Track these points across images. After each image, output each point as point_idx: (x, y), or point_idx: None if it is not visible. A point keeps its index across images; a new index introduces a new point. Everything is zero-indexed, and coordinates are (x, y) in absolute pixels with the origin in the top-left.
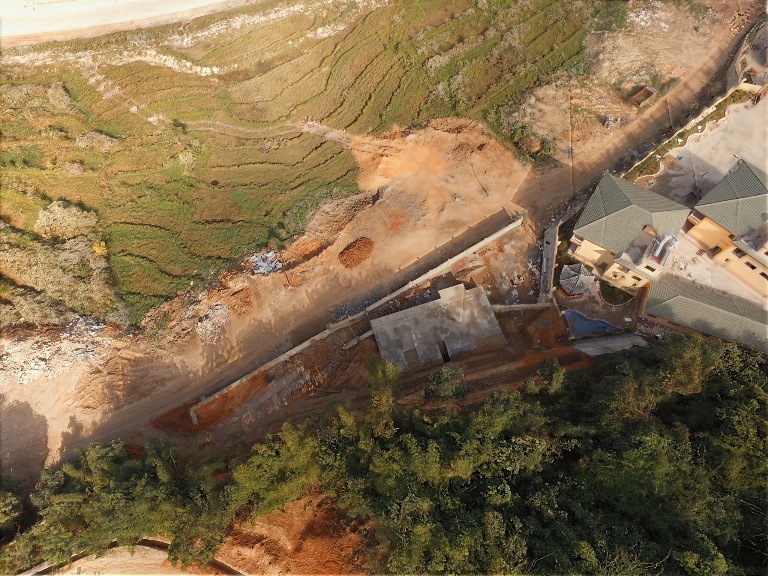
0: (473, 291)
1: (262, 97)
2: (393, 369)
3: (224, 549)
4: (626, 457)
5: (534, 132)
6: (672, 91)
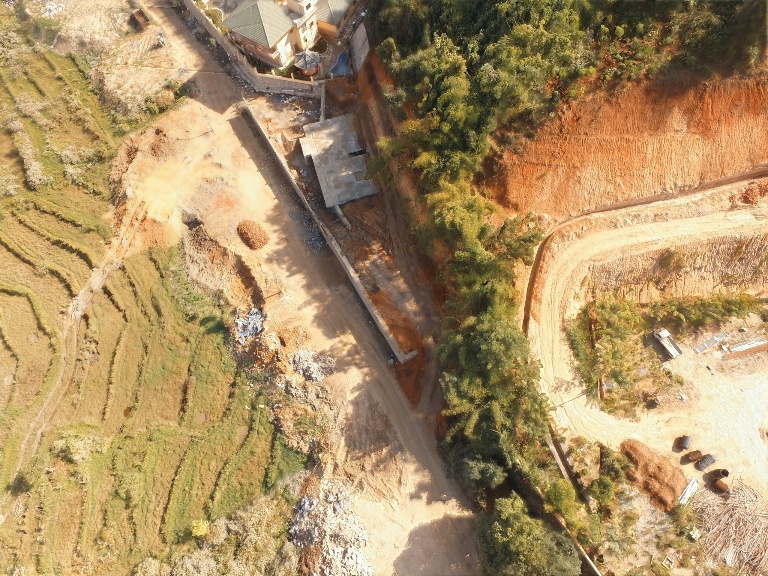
0: (307, 132)
1: (7, 375)
2: (382, 141)
3: (522, 266)
4: (445, 1)
5: (154, 92)
6: (140, 2)
